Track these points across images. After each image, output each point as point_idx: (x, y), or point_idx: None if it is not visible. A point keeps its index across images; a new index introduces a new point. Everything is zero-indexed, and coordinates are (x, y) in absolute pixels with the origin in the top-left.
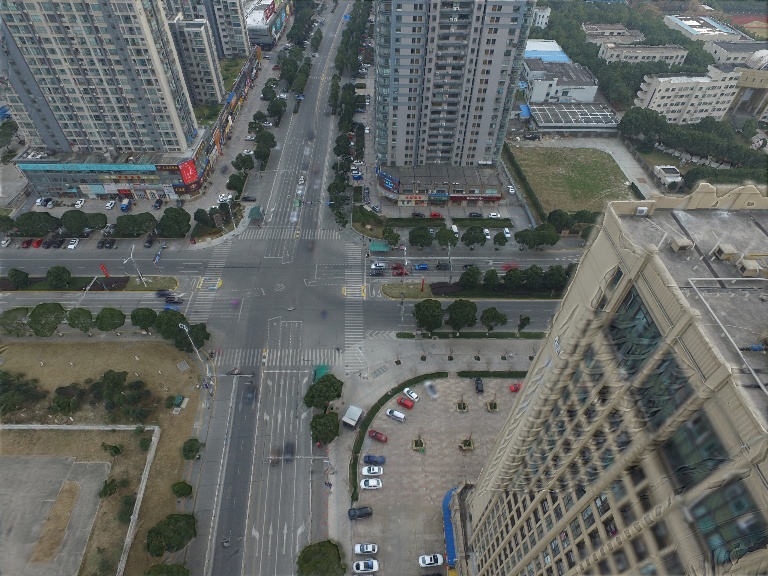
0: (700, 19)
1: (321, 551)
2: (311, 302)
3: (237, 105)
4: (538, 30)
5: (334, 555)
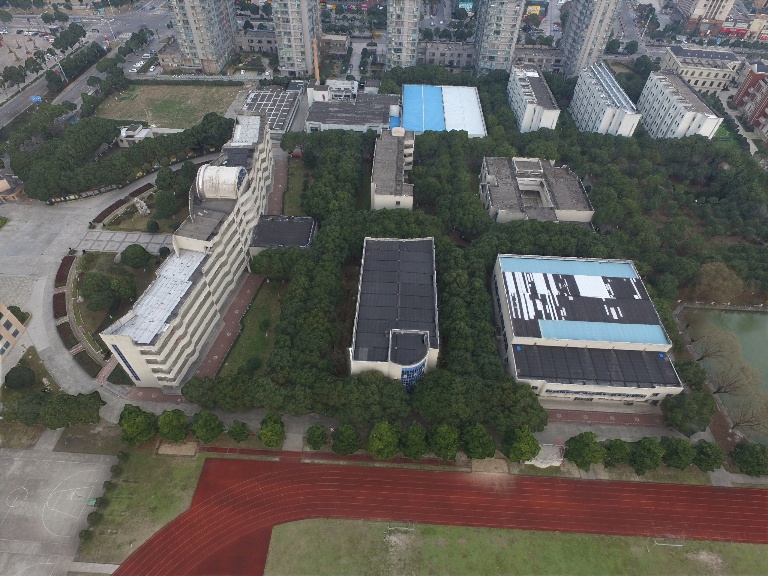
0: (635, 315)
1: (4, 12)
2: (127, 28)
3: (324, 4)
4: (504, 118)
5: (0, 13)
